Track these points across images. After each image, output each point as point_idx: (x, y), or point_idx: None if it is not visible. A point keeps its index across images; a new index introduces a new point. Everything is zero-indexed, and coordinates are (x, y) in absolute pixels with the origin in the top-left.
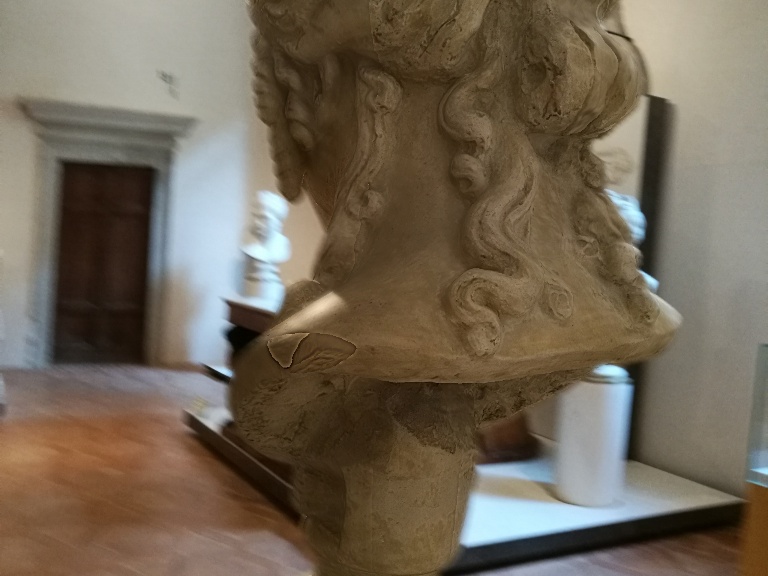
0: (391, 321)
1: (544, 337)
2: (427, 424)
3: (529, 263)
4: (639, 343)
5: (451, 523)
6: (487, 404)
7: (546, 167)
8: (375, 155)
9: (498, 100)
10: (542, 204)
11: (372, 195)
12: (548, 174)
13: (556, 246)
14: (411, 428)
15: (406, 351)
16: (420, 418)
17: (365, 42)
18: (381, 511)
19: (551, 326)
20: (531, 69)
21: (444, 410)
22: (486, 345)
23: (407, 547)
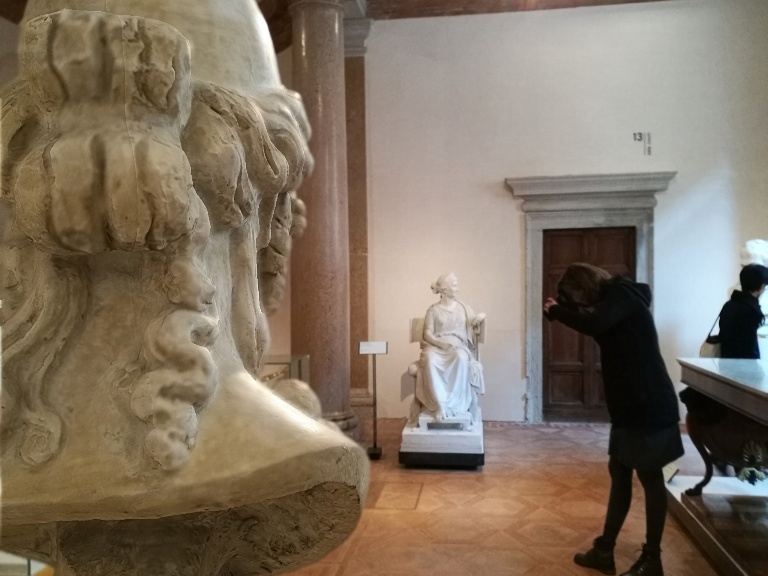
0: None
1: None
2: (94, 557)
3: None
4: (141, 495)
5: None
6: (271, 537)
7: (133, 285)
8: None
9: None
10: (104, 329)
11: None
12: (133, 293)
13: (92, 377)
14: (72, 560)
15: None
16: (89, 550)
17: None
18: None
19: (18, 472)
20: None
21: (127, 543)
22: None
23: None
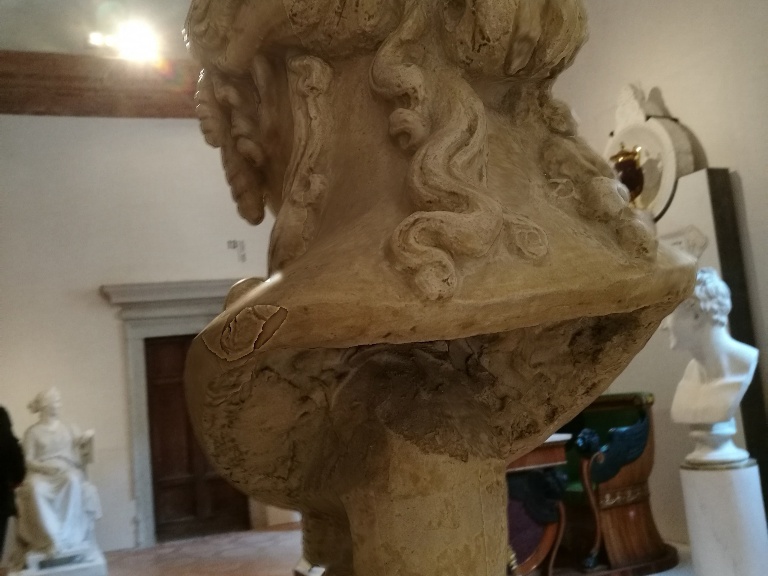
0: (327, 279)
1: (515, 278)
2: (427, 430)
3: (480, 197)
4: (640, 279)
5: (481, 548)
6: (514, 419)
7: (502, 120)
8: (312, 138)
9: (428, 51)
10: (501, 154)
11: (313, 177)
12: (506, 127)
13: (523, 192)
14: (408, 435)
15: (344, 305)
16: (418, 424)
17: (284, 28)
18: (391, 540)
19: (523, 267)
20: (452, 7)
21: (448, 415)
22: (438, 286)
23: None
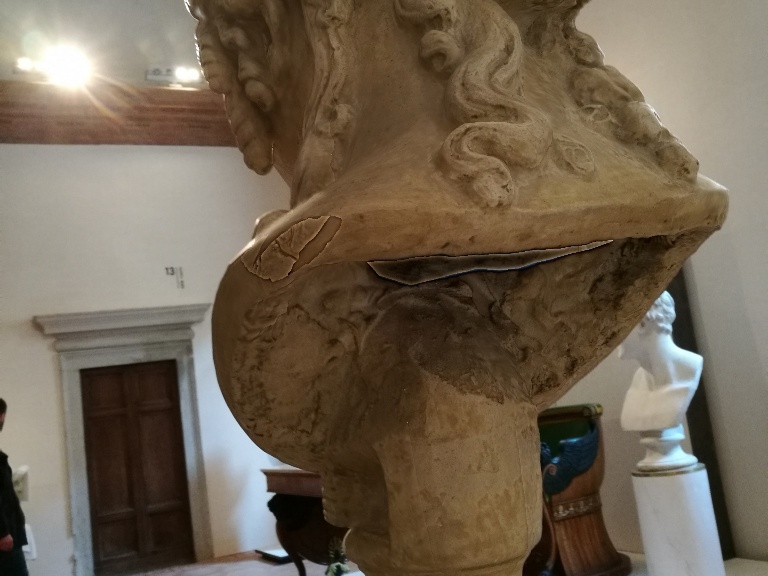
0: (379, 189)
1: (568, 190)
2: (462, 371)
3: (528, 109)
4: (684, 199)
5: (520, 493)
6: (534, 372)
7: (529, 51)
8: (336, 68)
9: None
10: (533, 82)
11: (340, 107)
12: (533, 57)
13: (559, 116)
14: (444, 376)
15: (402, 211)
16: (452, 366)
17: None
18: (430, 486)
19: (573, 181)
20: None
21: (480, 358)
22: (497, 192)
23: (471, 527)
